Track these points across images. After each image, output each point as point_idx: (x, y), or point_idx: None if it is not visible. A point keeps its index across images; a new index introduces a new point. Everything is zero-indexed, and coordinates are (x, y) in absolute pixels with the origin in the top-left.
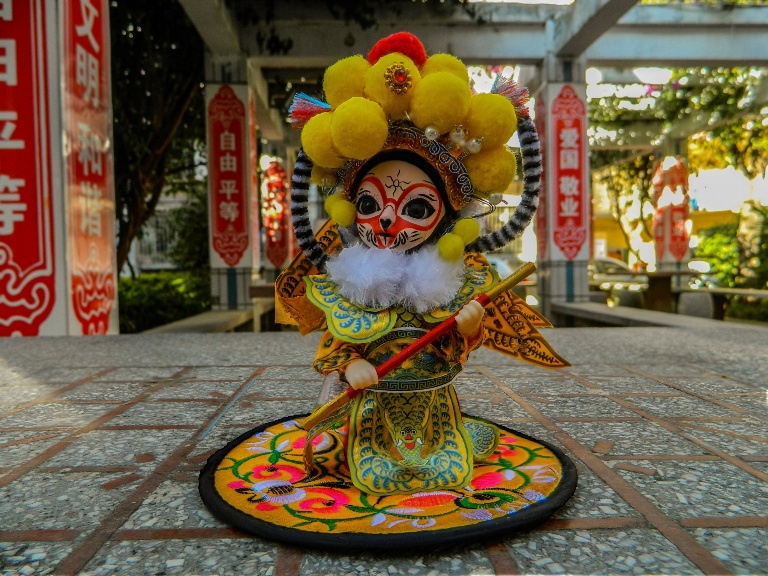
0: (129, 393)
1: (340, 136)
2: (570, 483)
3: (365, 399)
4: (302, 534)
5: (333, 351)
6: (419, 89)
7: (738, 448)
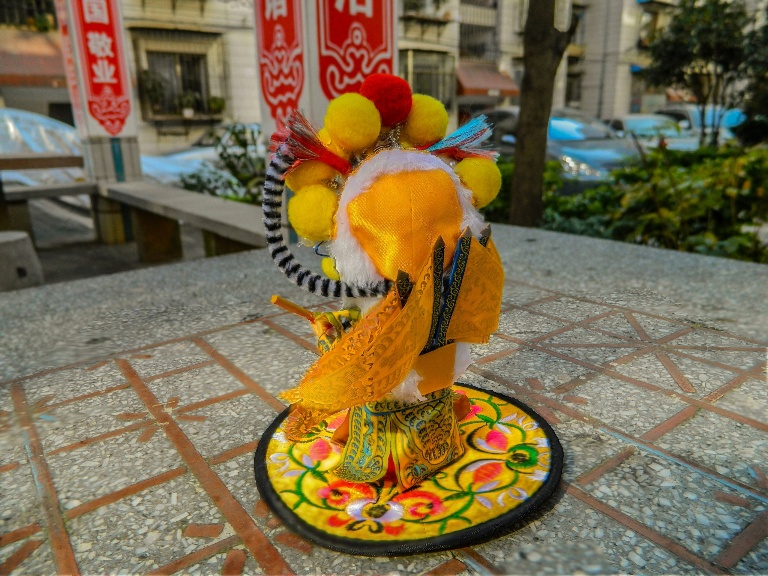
0: None
1: None
2: (258, 453)
3: None
4: None
5: None
6: None
7: None
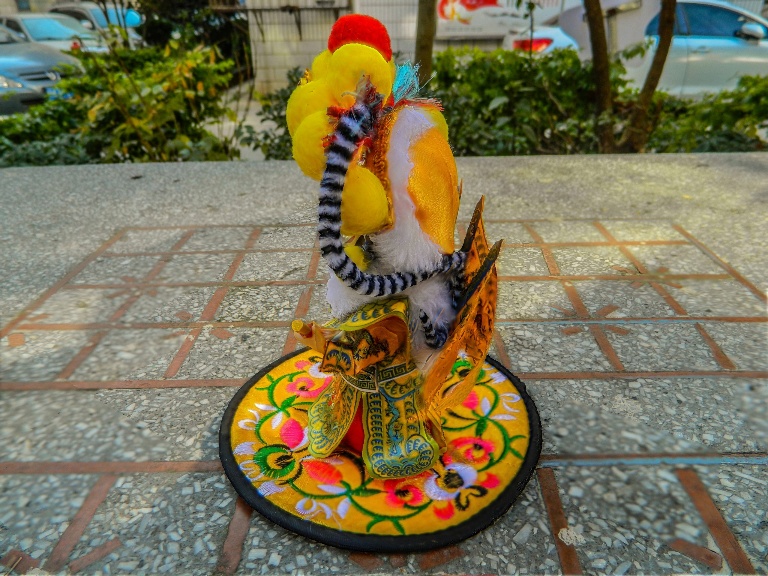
0: (588, 270)
1: None
2: (282, 518)
3: None
4: (252, 377)
5: None
6: None
7: None
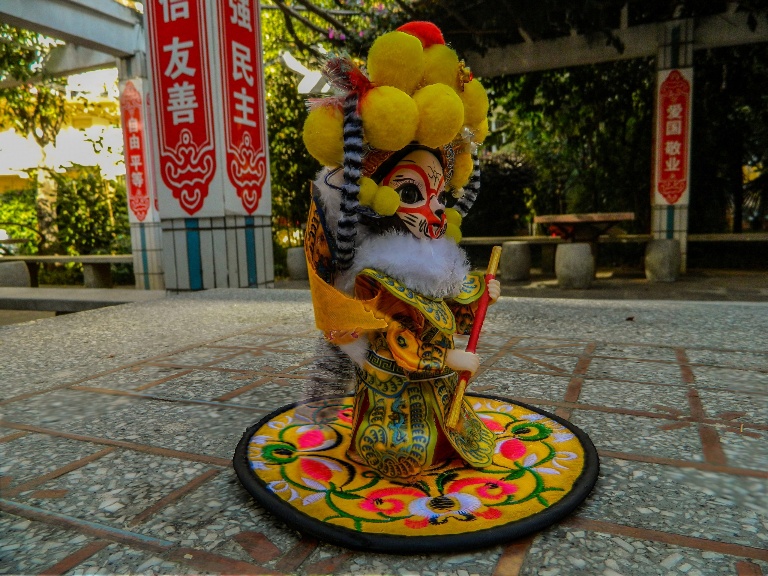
0: None
1: (448, 124)
2: None
3: (437, 388)
4: (571, 501)
5: (419, 348)
6: (470, 90)
7: None
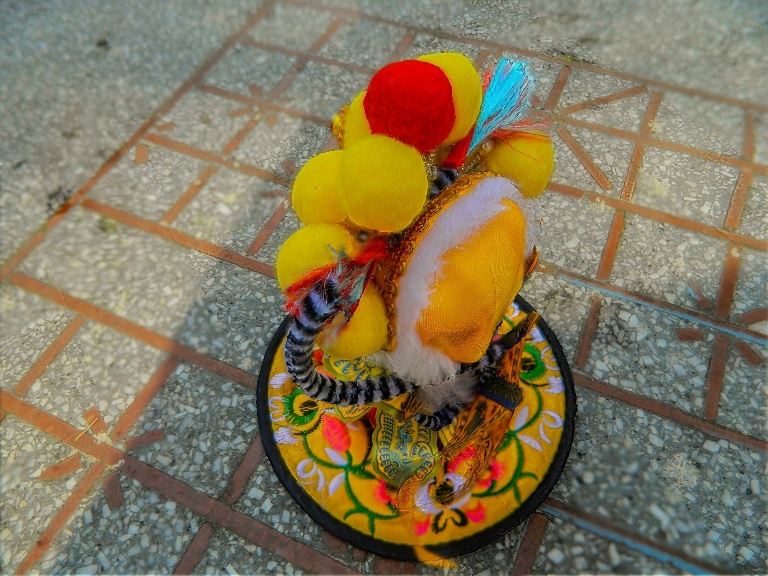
0: None
1: None
2: (282, 475)
3: None
4: None
5: None
6: None
7: None
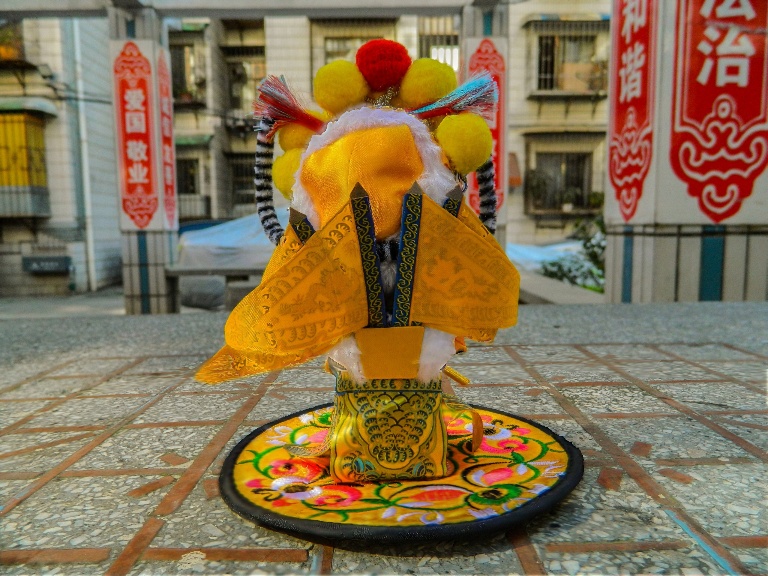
0: None
1: None
2: None
3: None
4: None
5: None
6: None
7: (0, 489)
